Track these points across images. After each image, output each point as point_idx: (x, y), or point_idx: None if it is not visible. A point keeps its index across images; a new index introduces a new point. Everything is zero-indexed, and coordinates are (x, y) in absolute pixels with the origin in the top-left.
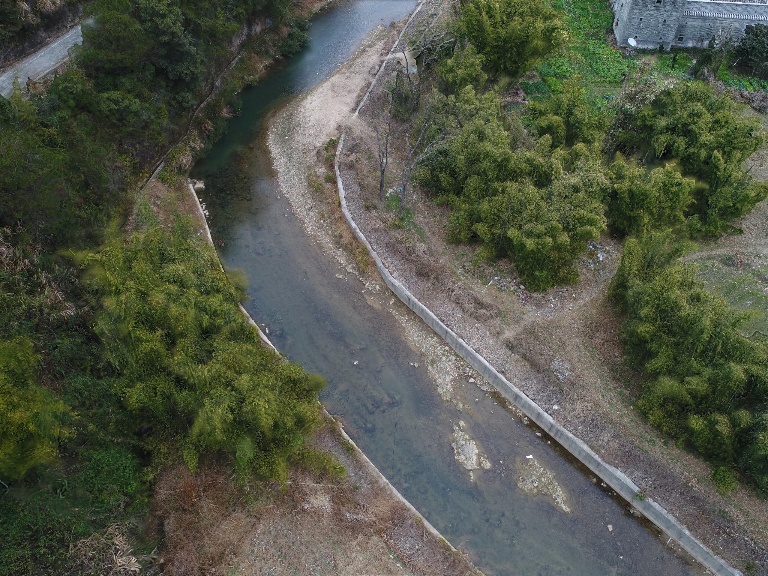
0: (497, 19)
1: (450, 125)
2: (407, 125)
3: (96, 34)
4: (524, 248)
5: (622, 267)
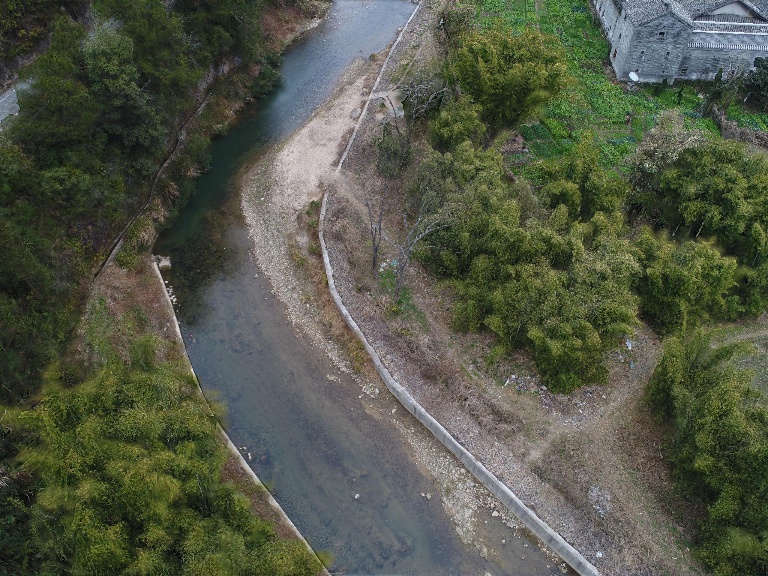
0: (494, 64)
1: (448, 188)
2: (397, 181)
3: (34, 102)
4: (548, 350)
5: (663, 371)
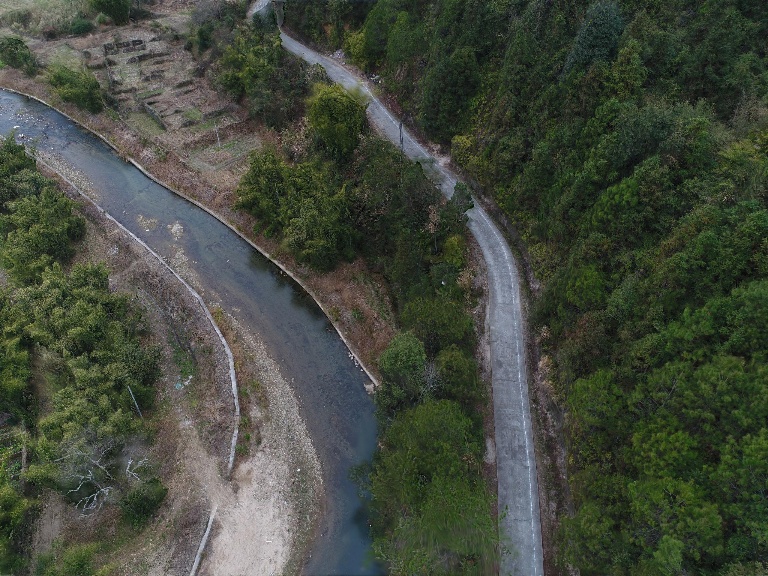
0: None
1: None
2: None
3: None
4: None
5: None
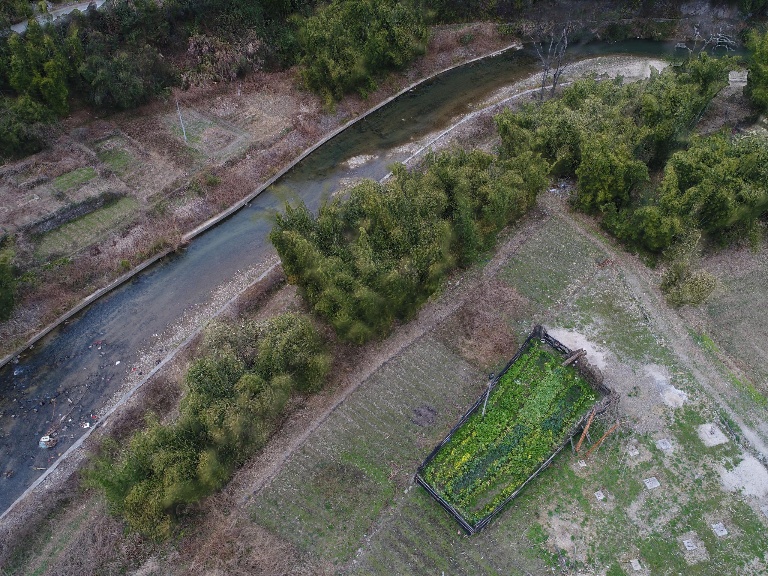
0: None
1: None
2: None
3: None
4: None
5: None
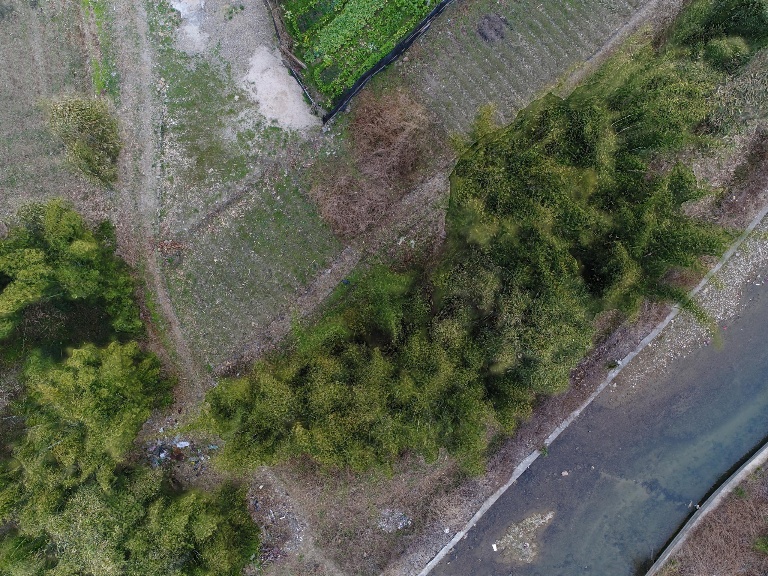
0: None
1: None
2: None
3: None
4: None
5: None
